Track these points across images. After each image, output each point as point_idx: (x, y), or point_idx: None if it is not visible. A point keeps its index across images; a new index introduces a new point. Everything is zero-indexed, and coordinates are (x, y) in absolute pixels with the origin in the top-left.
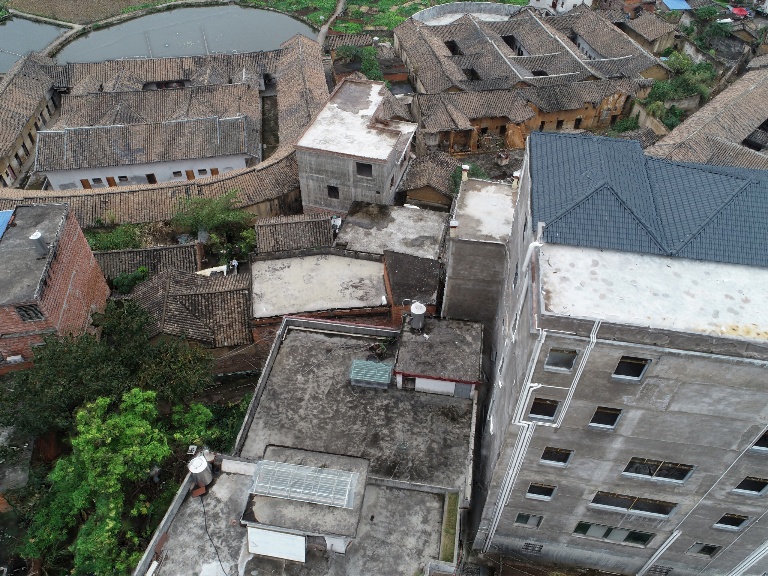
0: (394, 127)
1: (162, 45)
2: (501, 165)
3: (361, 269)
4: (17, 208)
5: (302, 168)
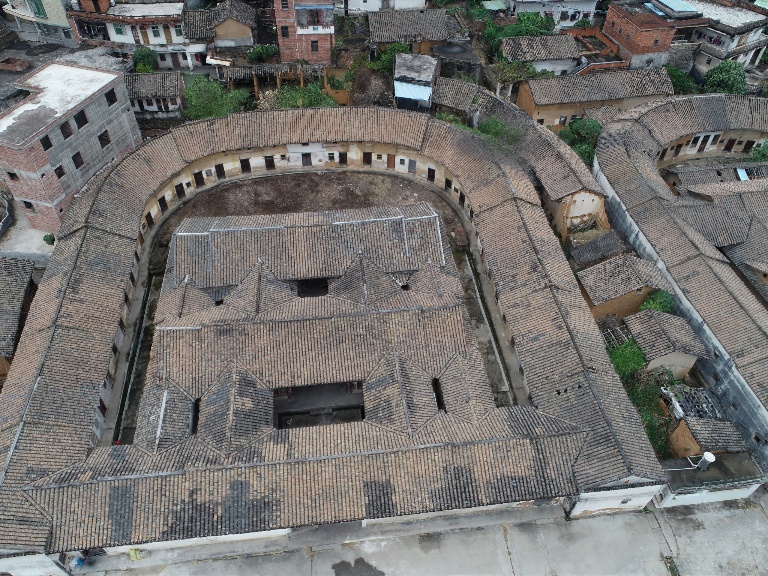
0: None
1: None
2: None
3: None
4: None
5: None
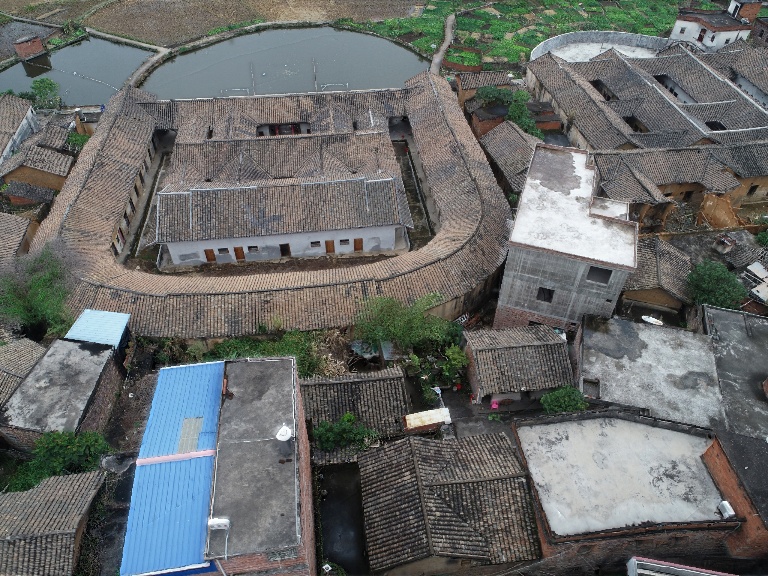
0: (601, 207)
1: (258, 74)
2: (722, 253)
3: (667, 445)
4: (226, 365)
5: (511, 266)
